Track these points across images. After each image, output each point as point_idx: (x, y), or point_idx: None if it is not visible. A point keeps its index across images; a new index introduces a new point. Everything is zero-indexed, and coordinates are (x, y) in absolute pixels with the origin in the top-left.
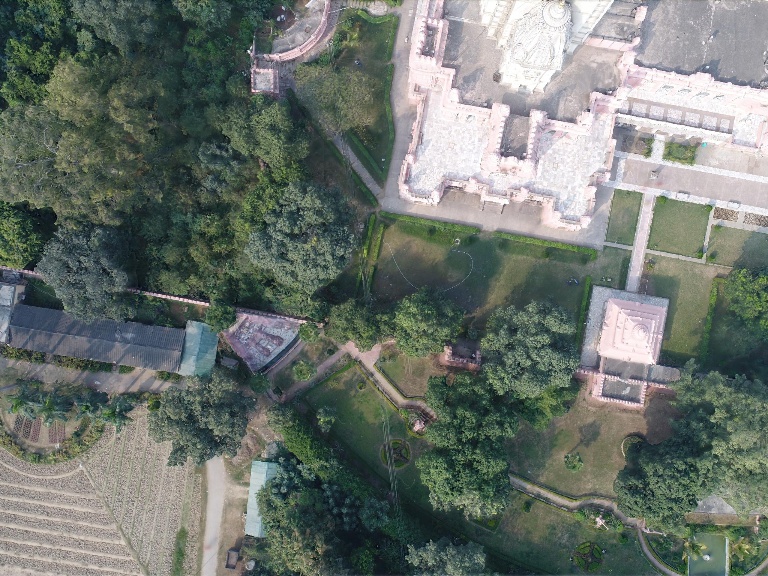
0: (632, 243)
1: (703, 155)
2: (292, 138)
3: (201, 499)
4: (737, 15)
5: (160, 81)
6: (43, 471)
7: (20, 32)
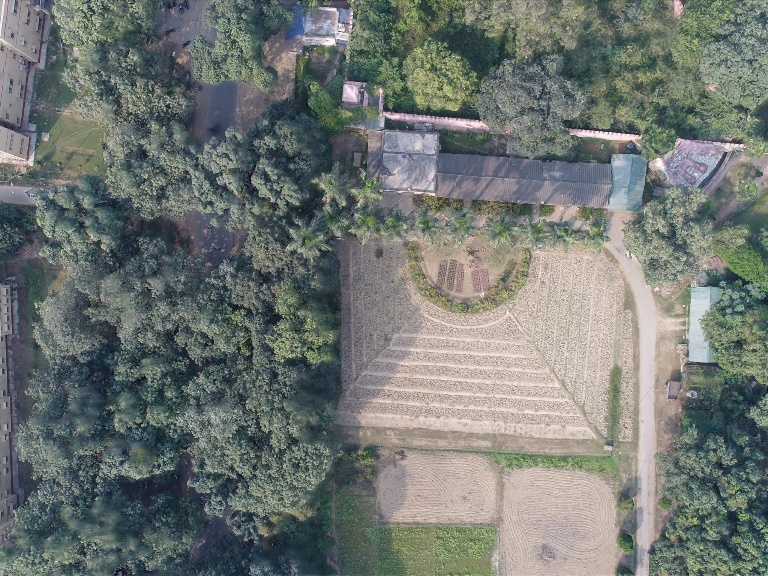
0: None
1: None
2: None
3: (632, 335)
4: None
5: None
6: (470, 321)
7: None
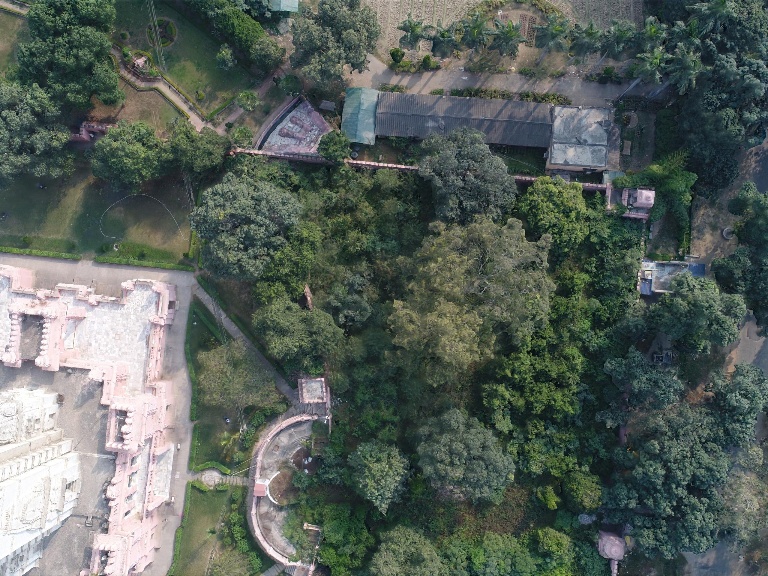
0: None
1: None
2: None
3: None
4: None
5: (418, 382)
6: None
7: (572, 425)
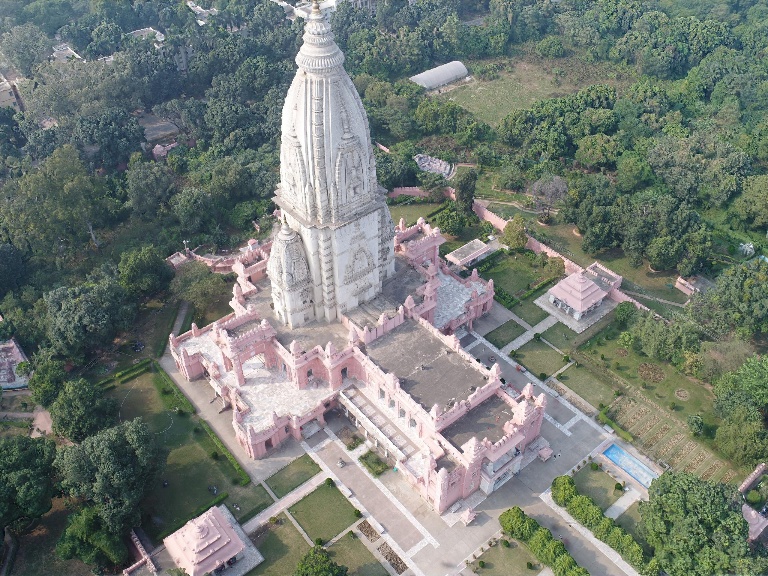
0: (281, 497)
1: (389, 477)
2: (146, 273)
3: None
4: (454, 368)
5: None
6: None
7: None
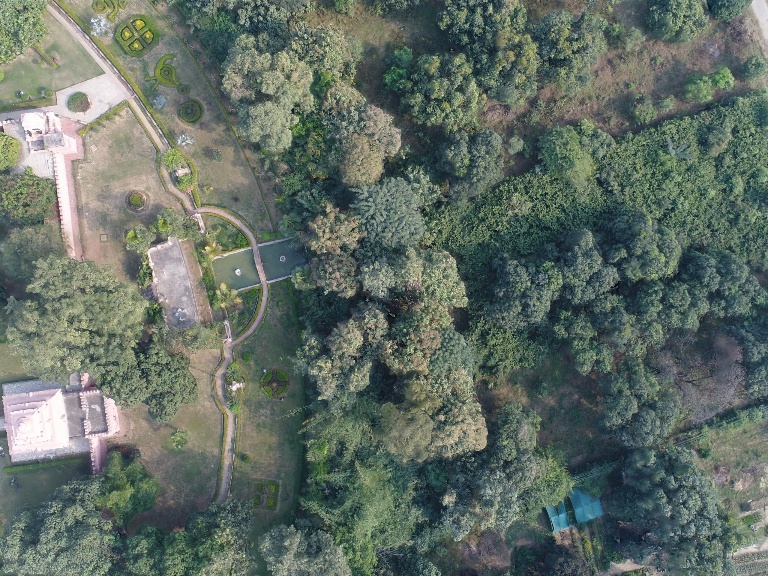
0: None
1: None
2: None
3: None
4: None
5: None
6: None
7: None
